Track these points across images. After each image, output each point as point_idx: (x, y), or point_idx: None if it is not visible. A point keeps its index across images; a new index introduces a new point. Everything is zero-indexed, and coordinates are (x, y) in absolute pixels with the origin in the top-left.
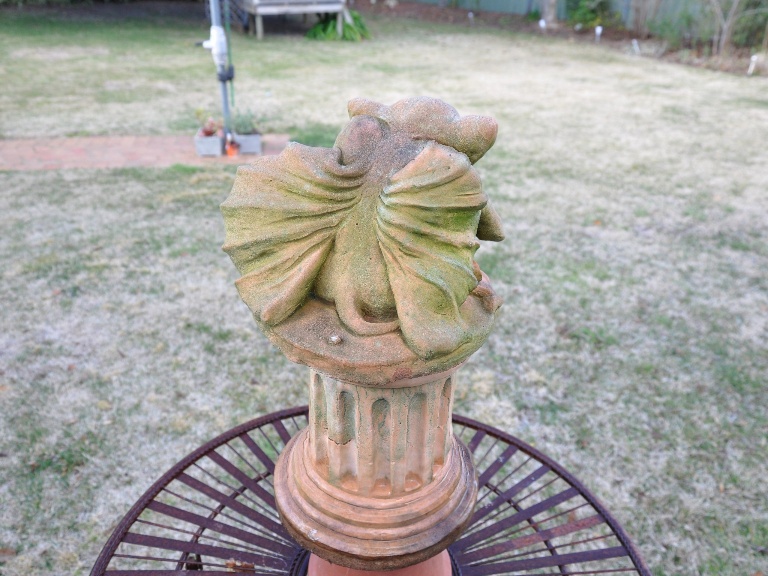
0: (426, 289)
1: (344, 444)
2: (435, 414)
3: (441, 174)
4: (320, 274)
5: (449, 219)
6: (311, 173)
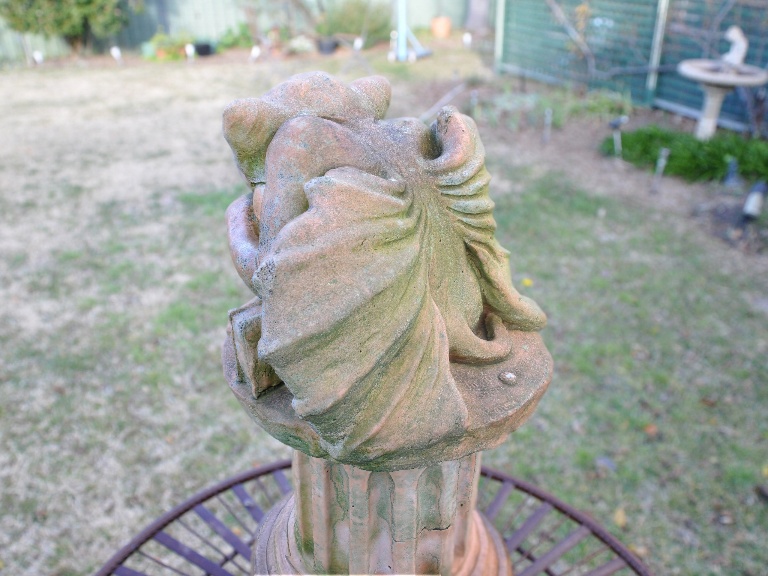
0: None
1: None
2: None
3: None
4: None
5: None
6: (395, 203)
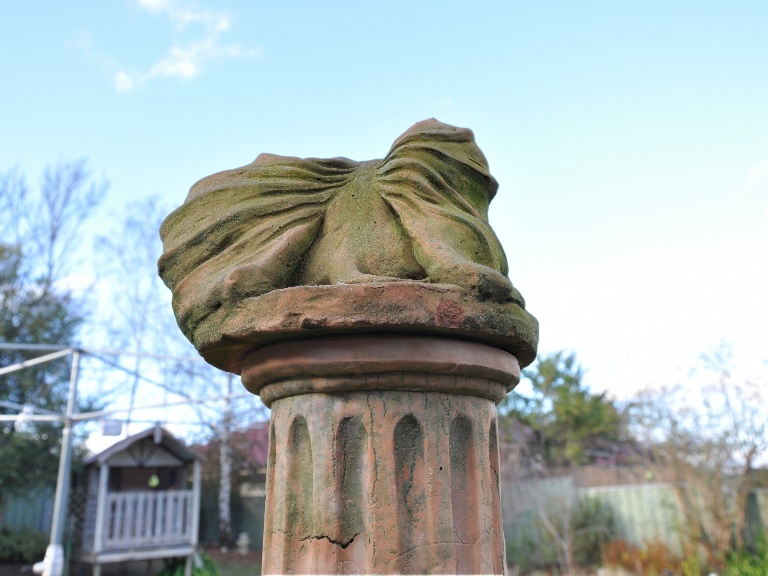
0: (456, 229)
1: (342, 547)
2: (486, 474)
3: (448, 131)
4: (303, 265)
5: (463, 183)
6: (293, 158)
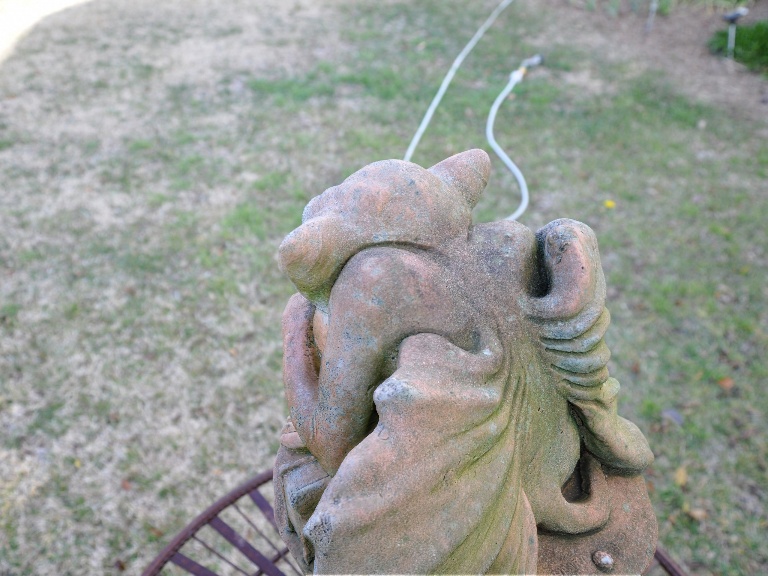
0: None
1: None
2: None
3: (599, 263)
4: None
5: None
6: (489, 404)
